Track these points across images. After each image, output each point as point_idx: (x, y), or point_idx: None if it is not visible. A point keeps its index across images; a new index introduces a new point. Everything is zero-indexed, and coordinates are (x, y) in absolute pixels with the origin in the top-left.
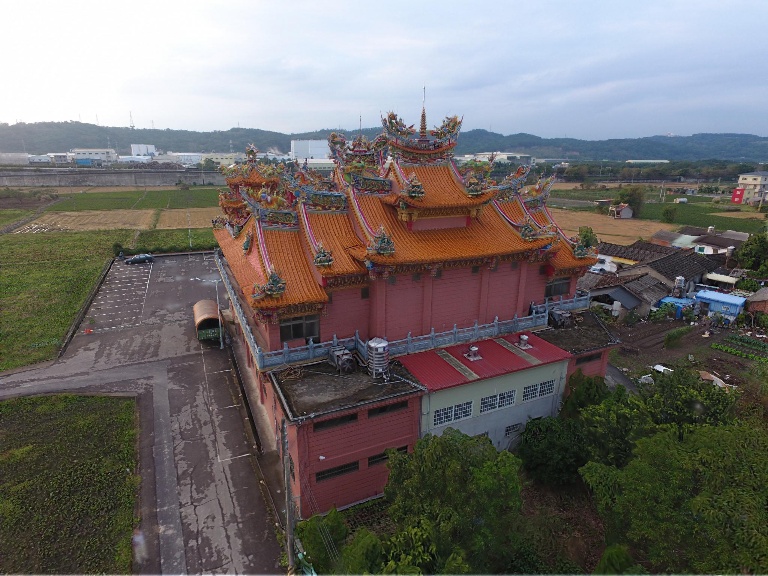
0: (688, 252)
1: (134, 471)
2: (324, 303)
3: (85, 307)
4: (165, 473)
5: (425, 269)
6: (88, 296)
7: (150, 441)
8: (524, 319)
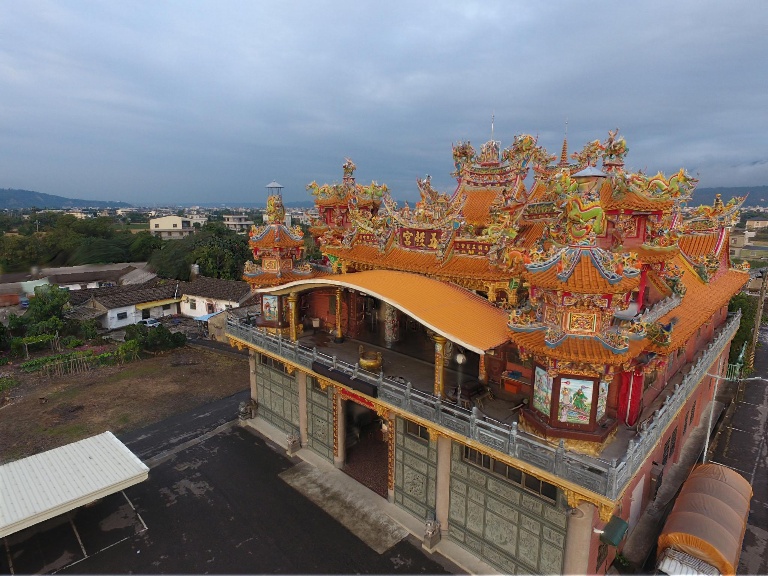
0: (140, 284)
1: None
2: None
3: None
4: None
5: None
6: None
7: None
8: None
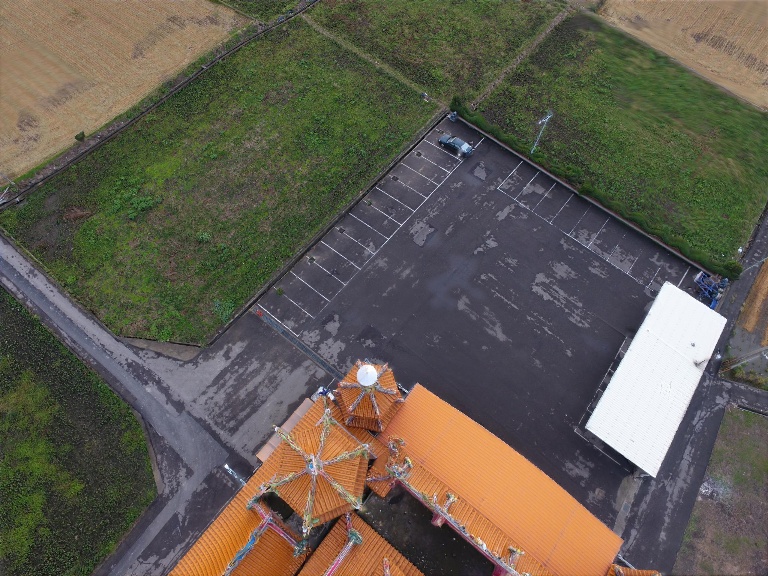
0: None
1: None
2: None
3: (309, 245)
4: None
5: None
6: (333, 218)
7: (104, 575)
8: None
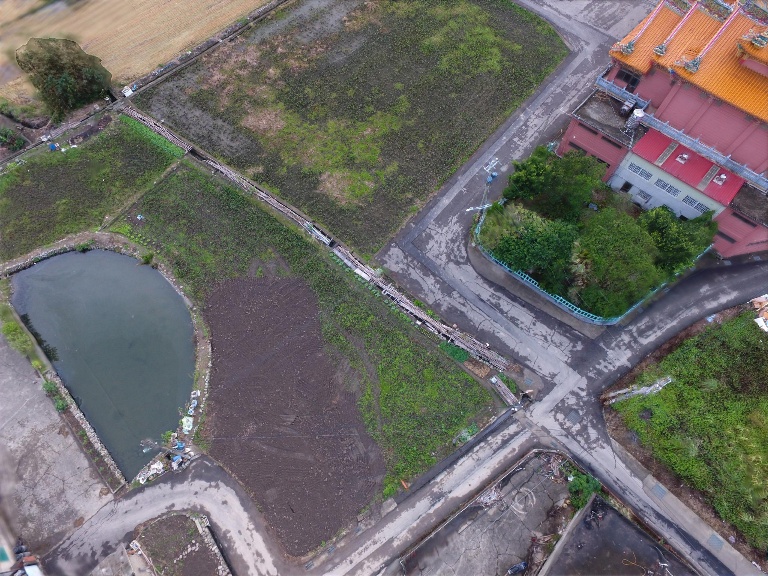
0: None
1: (536, 88)
2: (643, 74)
3: None
4: (542, 98)
5: (707, 95)
6: None
7: (552, 79)
8: (750, 172)
